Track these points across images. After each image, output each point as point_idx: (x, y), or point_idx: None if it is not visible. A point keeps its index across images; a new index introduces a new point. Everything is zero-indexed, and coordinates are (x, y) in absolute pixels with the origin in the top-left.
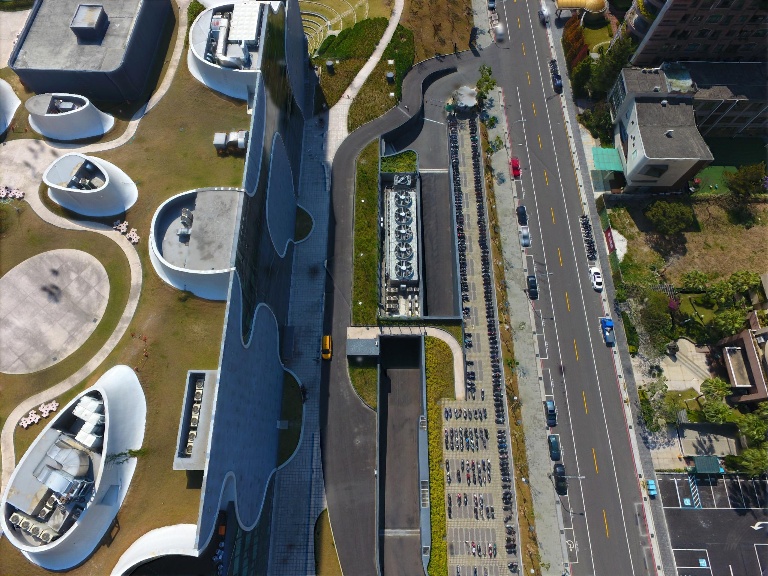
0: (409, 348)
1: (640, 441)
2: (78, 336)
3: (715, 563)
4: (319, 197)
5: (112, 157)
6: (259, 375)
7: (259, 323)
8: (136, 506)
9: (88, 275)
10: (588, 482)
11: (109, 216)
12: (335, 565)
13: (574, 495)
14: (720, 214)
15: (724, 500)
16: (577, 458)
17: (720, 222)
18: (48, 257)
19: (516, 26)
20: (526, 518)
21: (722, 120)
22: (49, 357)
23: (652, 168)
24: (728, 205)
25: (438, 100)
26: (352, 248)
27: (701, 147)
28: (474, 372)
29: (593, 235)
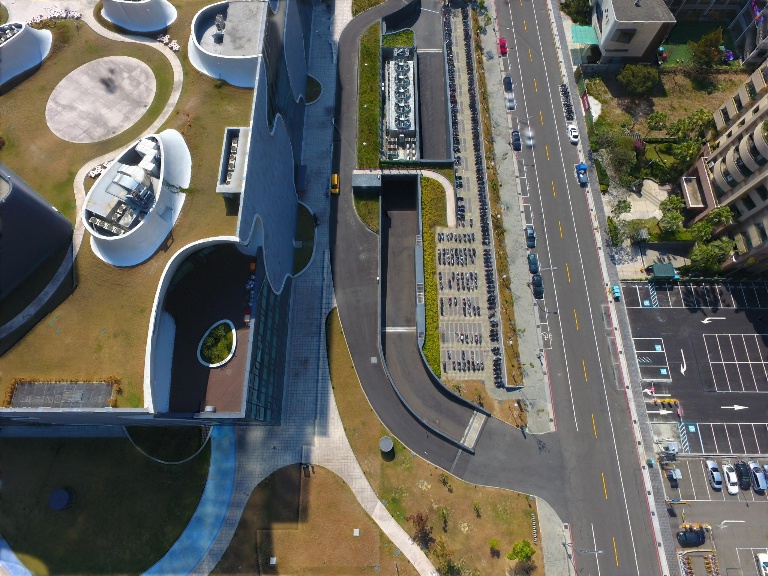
0: (407, 190)
1: (608, 259)
2: (132, 117)
3: (669, 348)
4: (327, 68)
5: None
6: (279, 175)
7: (279, 130)
8: (186, 226)
9: (138, 74)
10: (562, 289)
11: (153, 31)
12: (344, 348)
13: (549, 299)
14: (685, 83)
15: (679, 301)
16: (552, 271)
17: (685, 89)
18: (104, 62)
19: None
20: (507, 314)
21: (688, 1)
22: (109, 131)
23: (622, 33)
24: (691, 70)
25: None
26: (357, 108)
27: (665, 13)
28: (464, 205)
29: (571, 100)
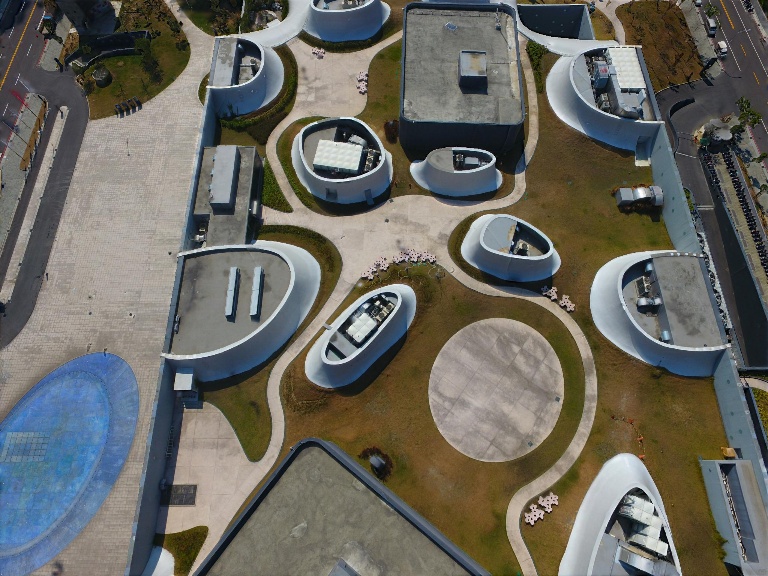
0: None
1: None
2: (546, 417)
3: None
4: None
5: (513, 215)
6: None
7: None
8: None
9: (531, 347)
10: None
11: (534, 281)
12: None
13: None
14: None
15: None
16: None
17: None
18: (481, 327)
19: (742, 54)
20: None
21: None
22: (524, 442)
23: None
24: None
25: (685, 132)
26: None
27: None
28: None
29: None
